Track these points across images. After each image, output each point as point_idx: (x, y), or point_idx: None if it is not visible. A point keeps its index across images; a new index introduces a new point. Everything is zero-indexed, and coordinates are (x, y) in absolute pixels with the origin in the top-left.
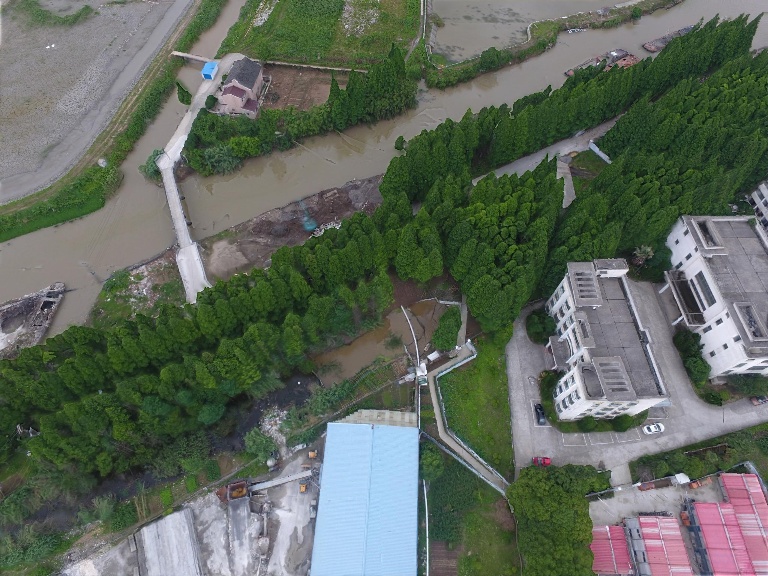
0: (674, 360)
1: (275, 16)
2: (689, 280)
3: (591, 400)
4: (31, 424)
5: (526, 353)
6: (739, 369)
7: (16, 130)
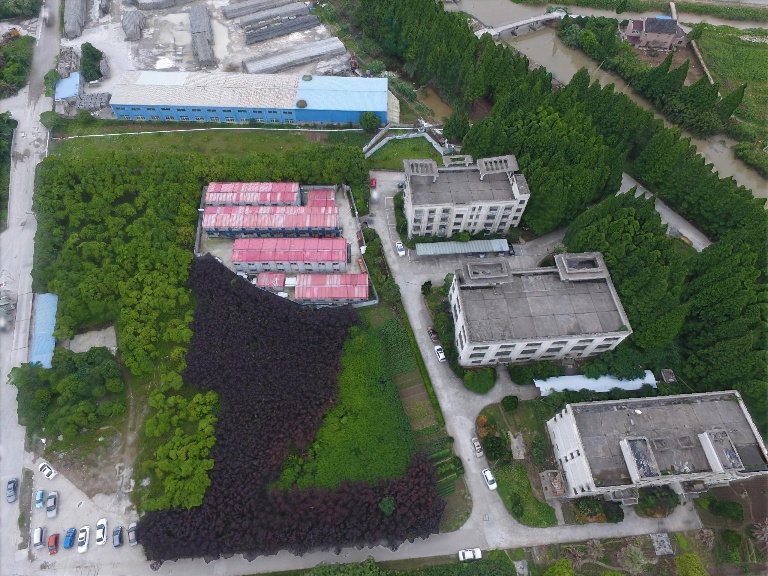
0: None
1: (763, 46)
2: None
3: None
4: None
5: None
6: None
7: None
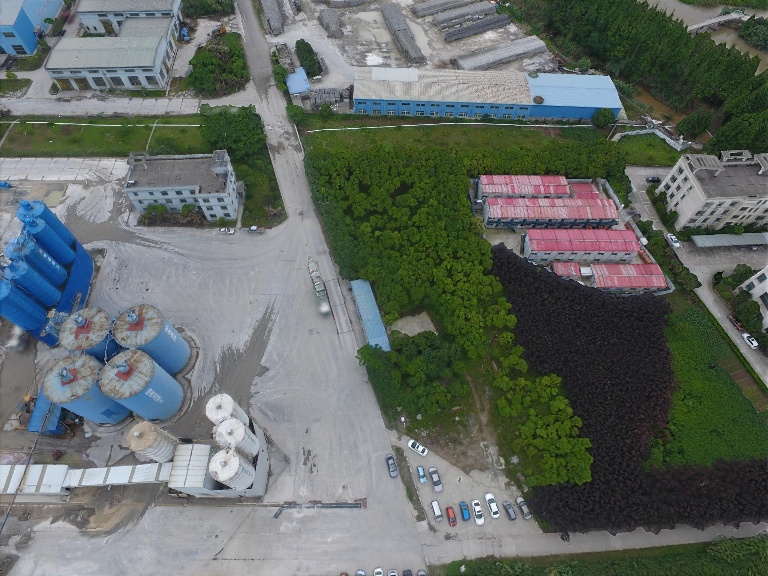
0: None
1: None
2: None
3: None
4: None
5: None
6: (758, 288)
7: None
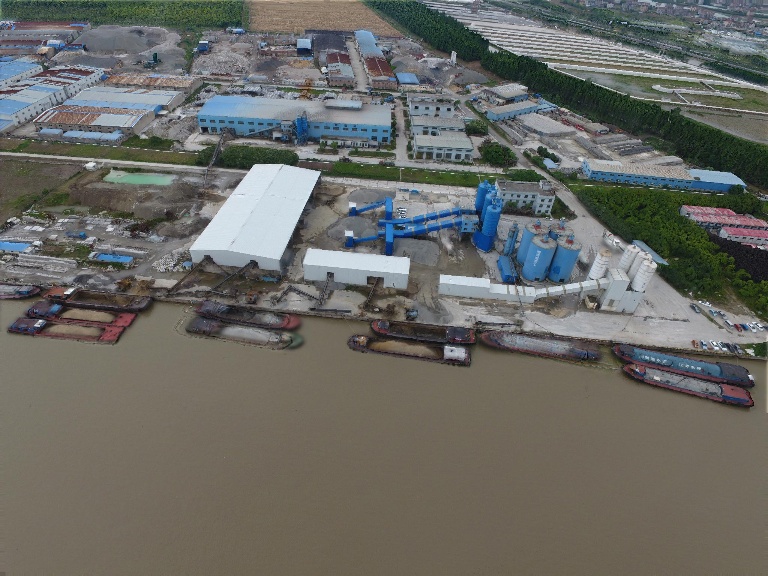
0: None
1: None
2: None
3: None
4: None
5: None
6: None
7: (765, 135)
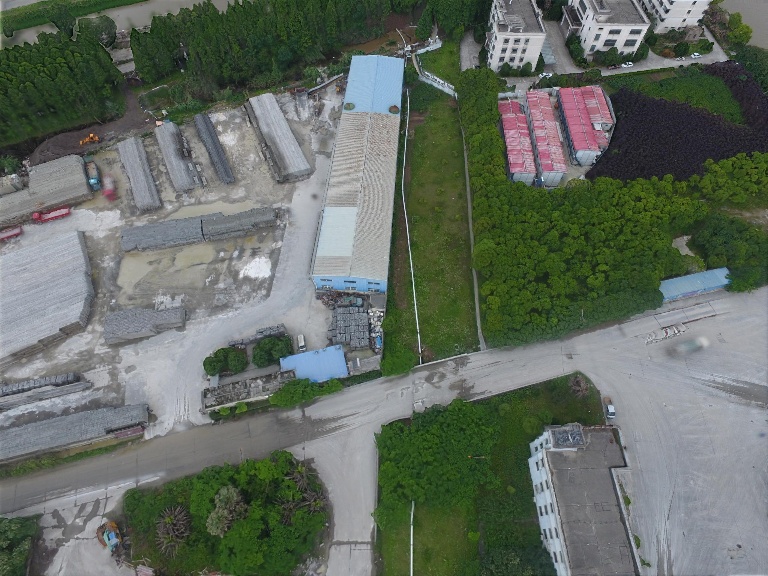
0: (564, 52)
1: None
2: (576, 9)
3: (502, 34)
4: (181, 60)
5: (473, 48)
6: (599, 44)
7: None
